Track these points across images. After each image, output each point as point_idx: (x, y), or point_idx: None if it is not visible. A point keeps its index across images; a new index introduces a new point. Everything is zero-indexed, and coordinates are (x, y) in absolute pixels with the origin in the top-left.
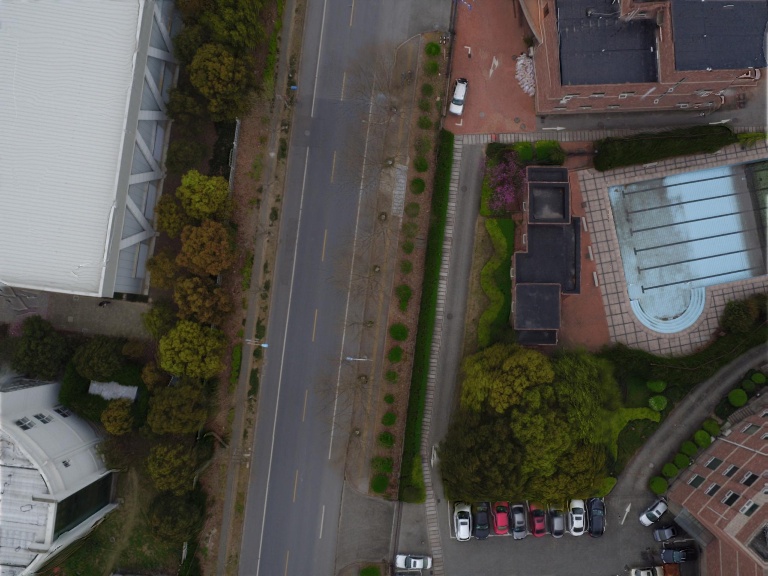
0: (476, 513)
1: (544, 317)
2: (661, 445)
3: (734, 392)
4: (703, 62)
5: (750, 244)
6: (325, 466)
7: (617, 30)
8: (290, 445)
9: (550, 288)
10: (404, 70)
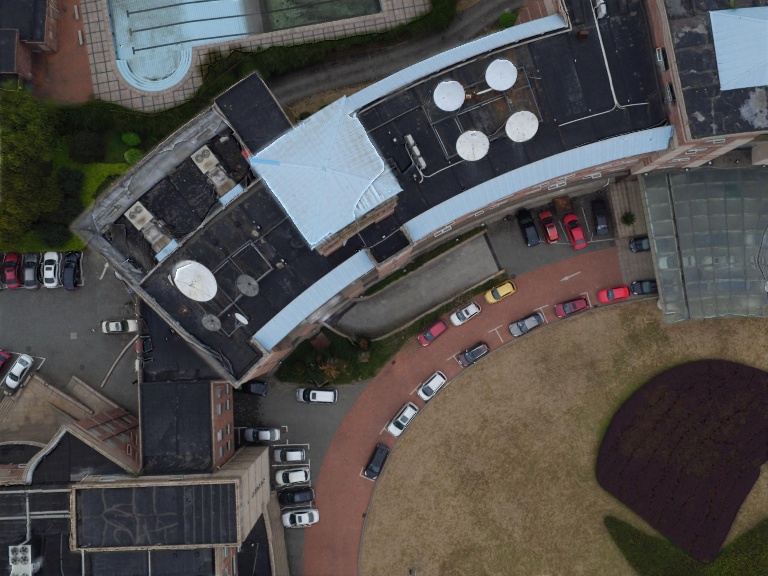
0: None
1: None
2: None
3: None
4: None
5: (249, 9)
6: None
7: None
8: None
9: (7, 33)
10: None
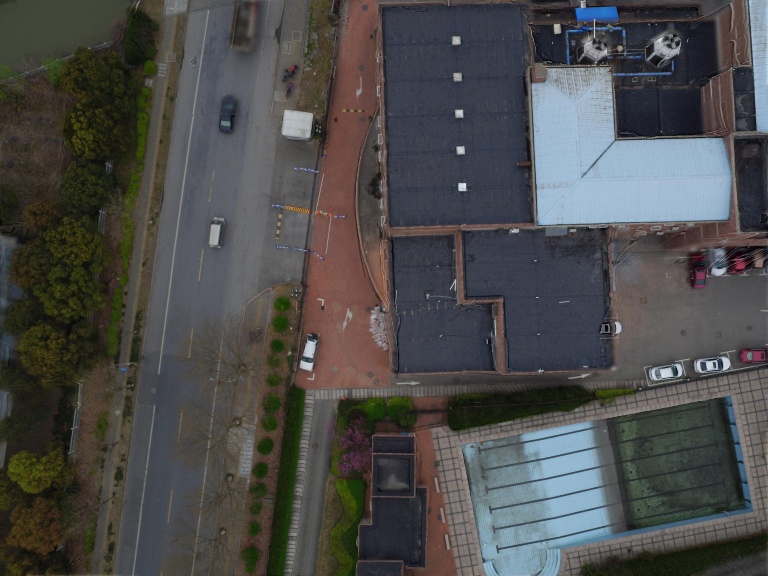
0: None
1: None
2: None
3: None
4: (536, 362)
5: (611, 499)
6: None
7: (455, 315)
8: None
9: (392, 566)
10: (253, 327)
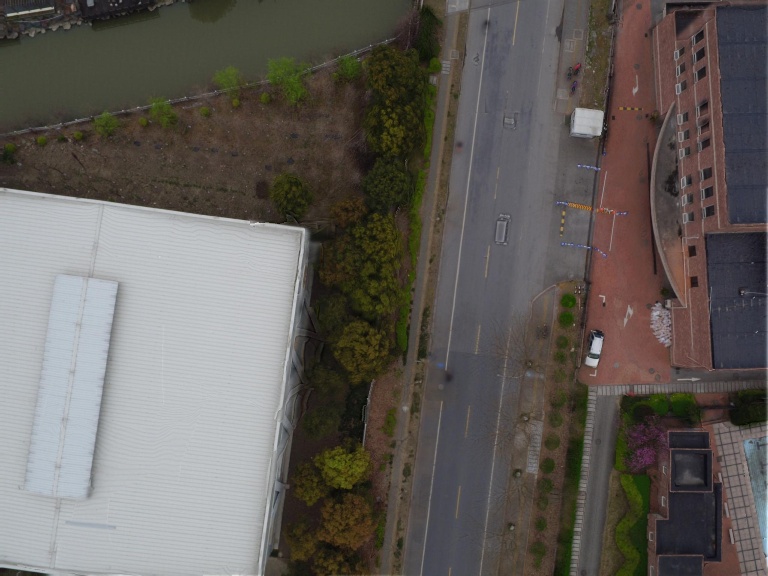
0: None
1: None
2: None
3: None
4: None
5: None
6: None
7: None
8: None
9: (693, 560)
10: (540, 323)
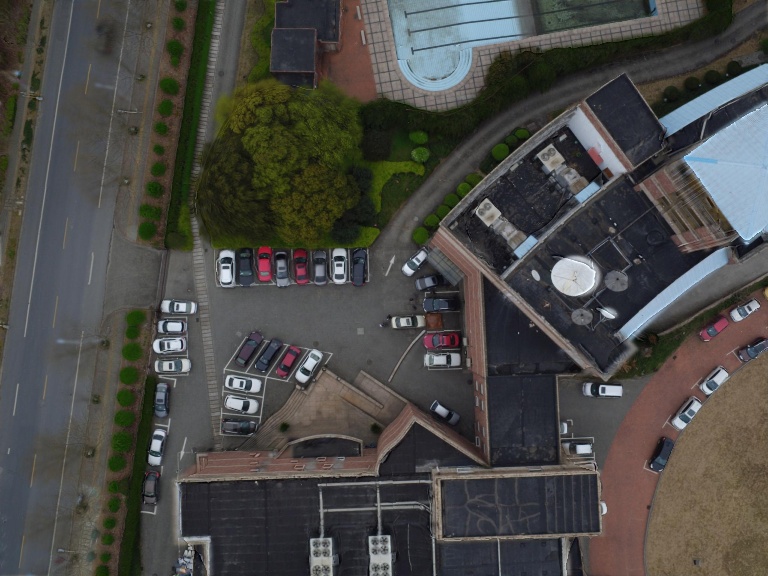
0: (239, 259)
1: (299, 60)
2: (426, 199)
3: (497, 146)
4: None
5: (522, 11)
6: (95, 214)
7: None
8: (61, 194)
9: (306, 32)
10: None
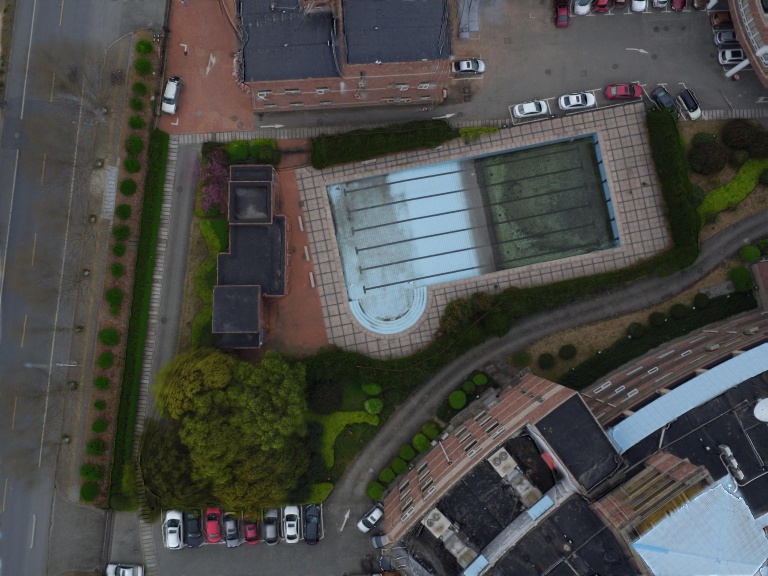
0: (186, 521)
1: (242, 320)
2: (381, 449)
3: (454, 394)
4: (373, 55)
5: (479, 241)
6: (35, 474)
7: (299, 24)
8: None
9: (249, 290)
10: (114, 69)
